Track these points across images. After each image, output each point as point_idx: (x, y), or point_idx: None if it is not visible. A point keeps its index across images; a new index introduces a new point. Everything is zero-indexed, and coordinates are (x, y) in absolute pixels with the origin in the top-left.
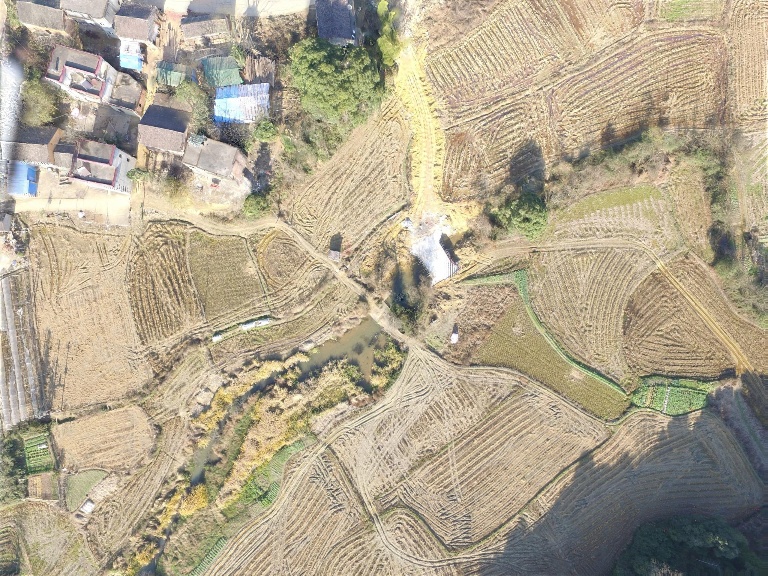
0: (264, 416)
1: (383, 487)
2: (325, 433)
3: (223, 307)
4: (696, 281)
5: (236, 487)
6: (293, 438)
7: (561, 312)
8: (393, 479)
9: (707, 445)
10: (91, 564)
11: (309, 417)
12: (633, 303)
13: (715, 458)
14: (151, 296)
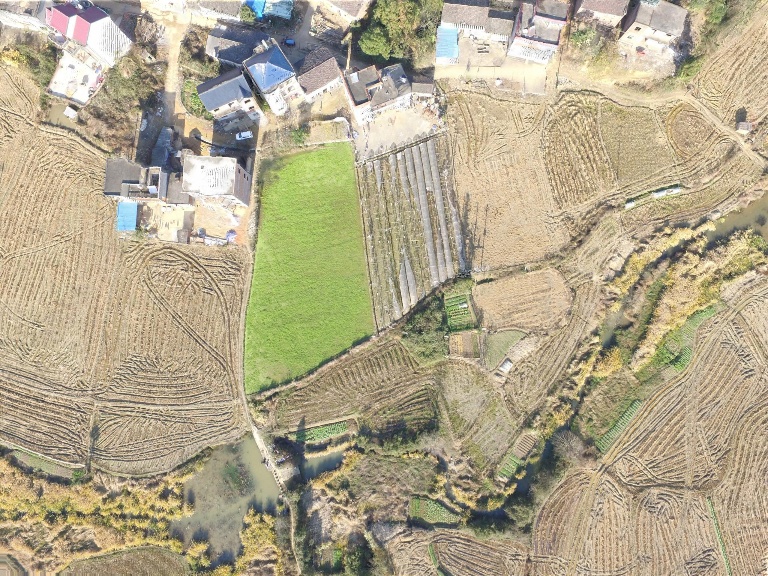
0: (678, 281)
1: None
2: (735, 300)
3: (635, 175)
4: None
5: (651, 350)
6: (707, 303)
7: None
8: None
9: None
10: (508, 423)
11: (721, 283)
12: None
13: None
14: (565, 163)
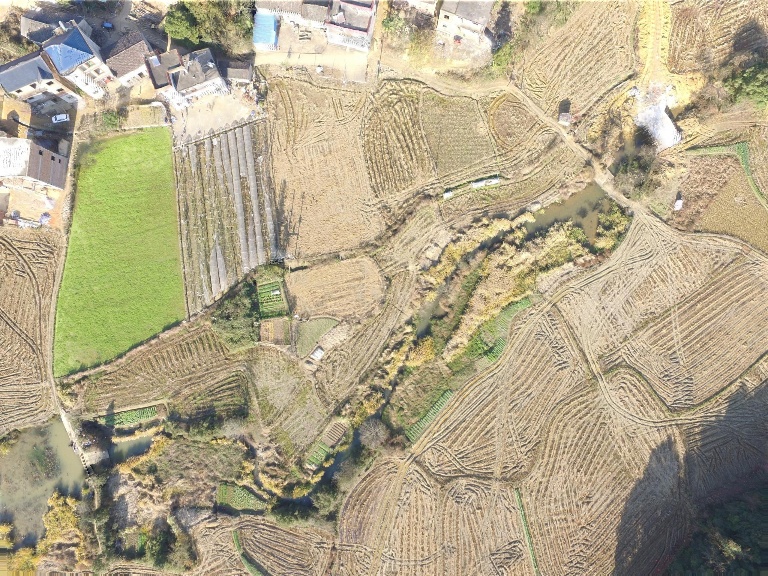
0: (493, 272)
1: (607, 347)
2: (551, 292)
3: (454, 165)
4: None
5: (464, 340)
6: (521, 294)
7: None
8: (617, 339)
9: None
10: (318, 411)
11: (537, 275)
12: None
13: None
14: (384, 151)
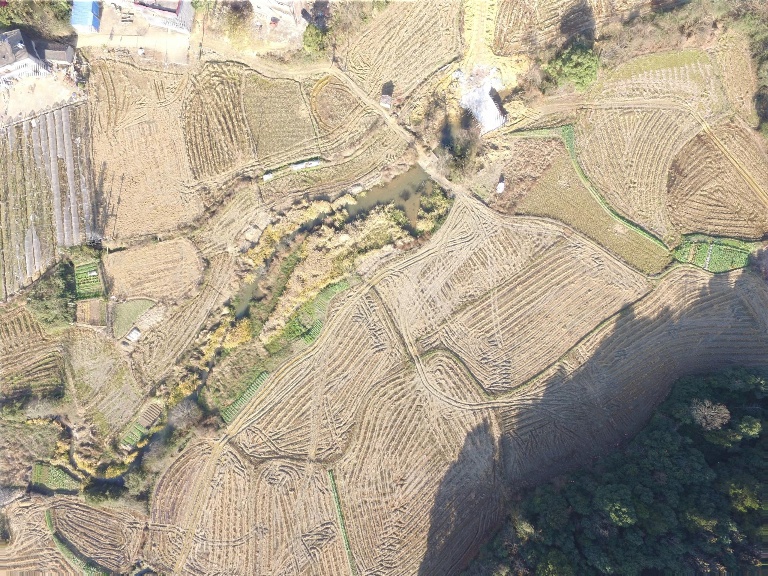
0: (311, 253)
1: (425, 329)
2: (370, 274)
3: (275, 147)
4: (741, 144)
5: (280, 322)
6: (338, 276)
7: (606, 168)
8: (435, 322)
9: (748, 303)
10: (134, 392)
11: (355, 257)
12: (678, 163)
13: (755, 316)
14: (205, 133)
